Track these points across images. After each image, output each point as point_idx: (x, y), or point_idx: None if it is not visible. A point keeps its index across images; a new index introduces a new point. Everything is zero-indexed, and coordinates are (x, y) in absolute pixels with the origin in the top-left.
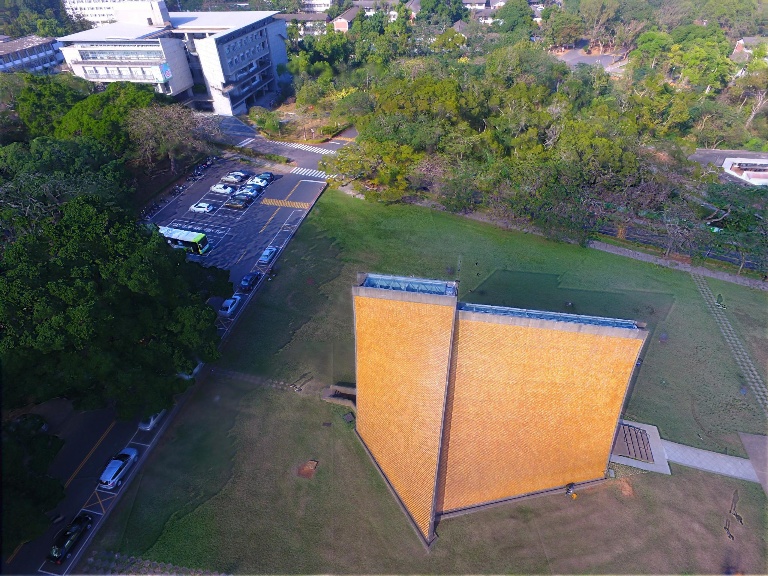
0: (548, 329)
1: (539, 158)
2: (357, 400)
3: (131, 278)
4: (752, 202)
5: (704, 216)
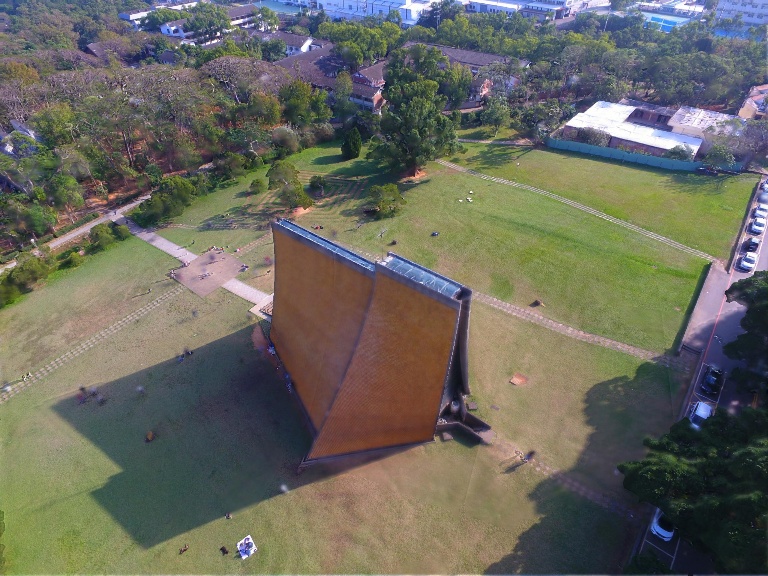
0: None
1: None
2: None
3: None
4: None
5: None
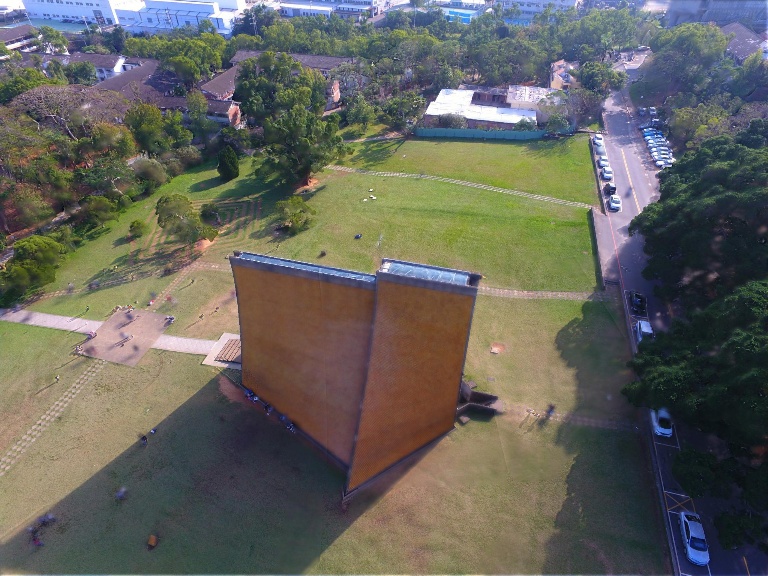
0: None
1: None
2: None
3: None
4: None
5: None
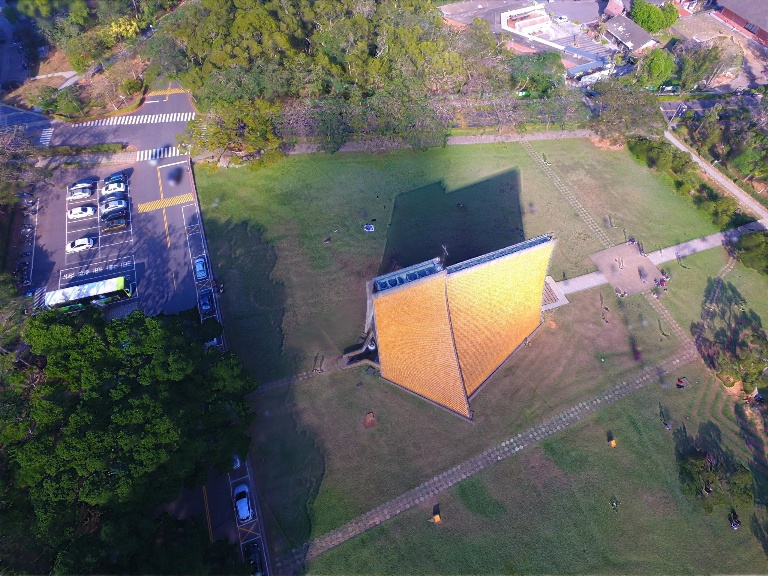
0: (501, 262)
1: (385, 78)
2: (380, 359)
3: (169, 371)
4: (542, 69)
5: (513, 88)
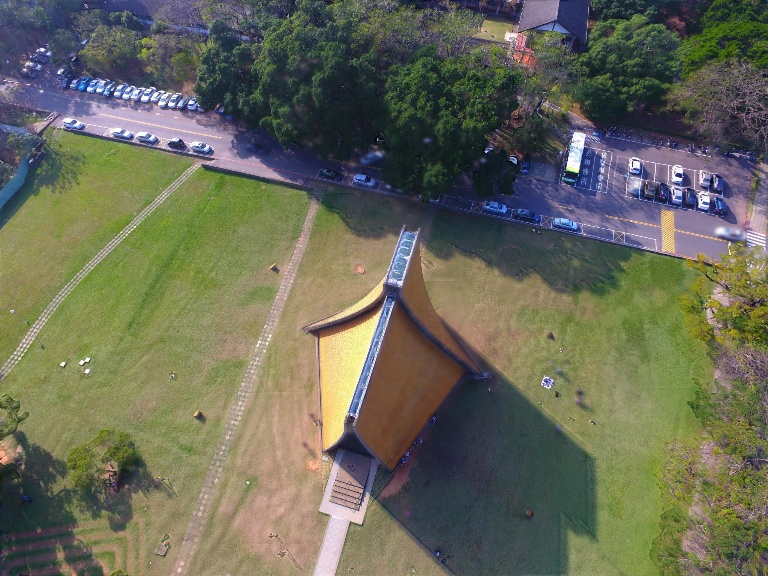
0: None
1: None
2: None
3: None
4: None
5: None
